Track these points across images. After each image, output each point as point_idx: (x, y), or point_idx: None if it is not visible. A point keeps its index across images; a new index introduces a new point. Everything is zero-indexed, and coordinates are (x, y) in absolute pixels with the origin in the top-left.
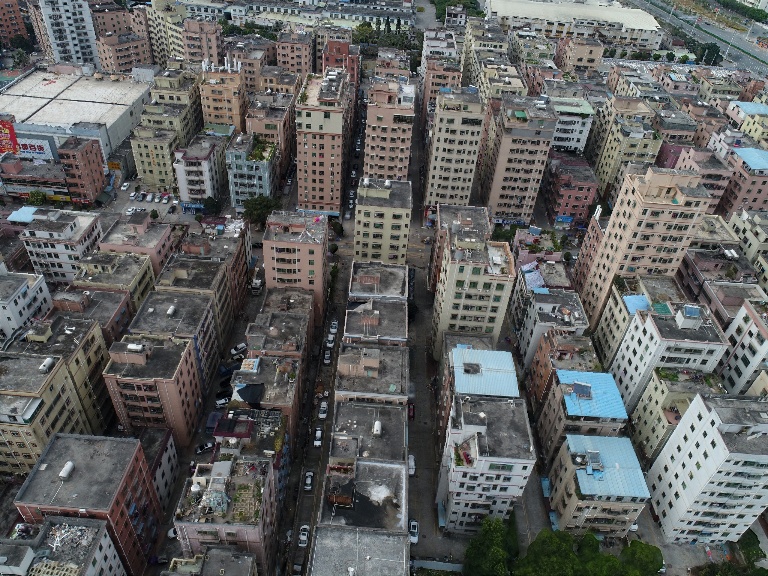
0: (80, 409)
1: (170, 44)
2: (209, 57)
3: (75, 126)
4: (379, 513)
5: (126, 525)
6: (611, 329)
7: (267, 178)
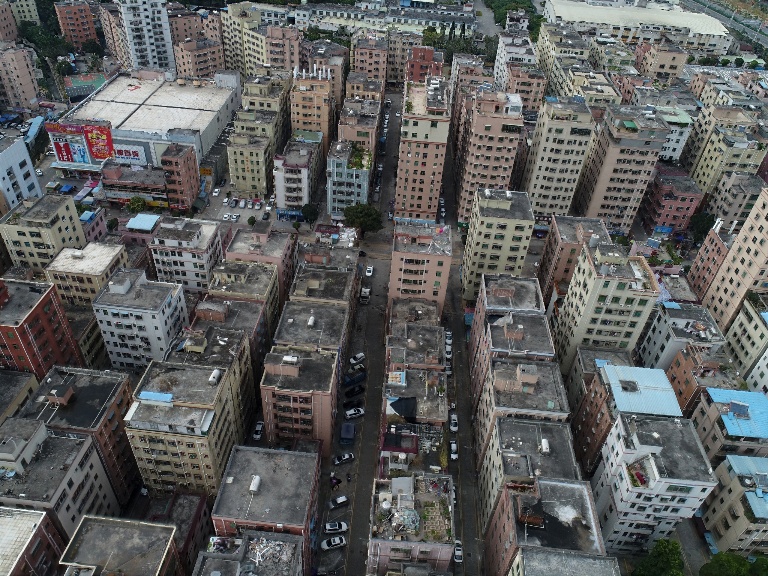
0: (234, 419)
1: (245, 49)
2: (290, 63)
3: (170, 132)
4: (571, 534)
5: (308, 539)
6: (743, 345)
7: (366, 186)
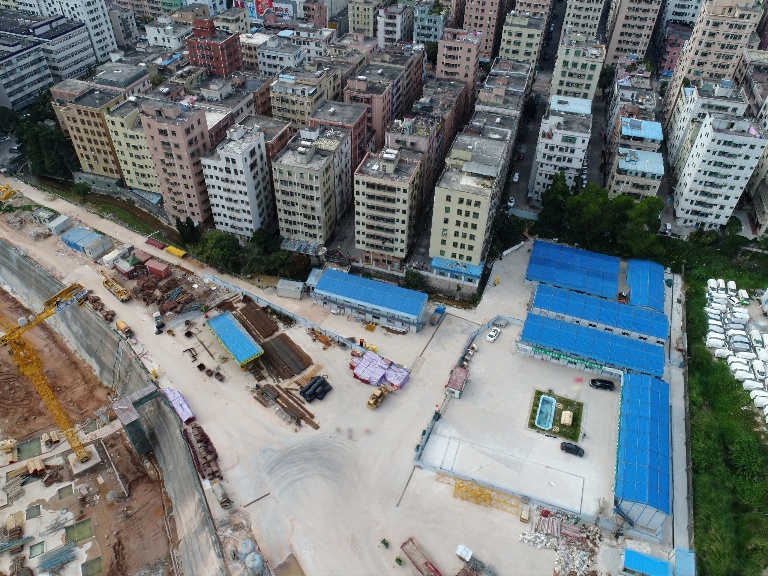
0: None
1: None
2: None
3: None
4: None
5: (356, 148)
6: (675, 116)
7: (441, 30)
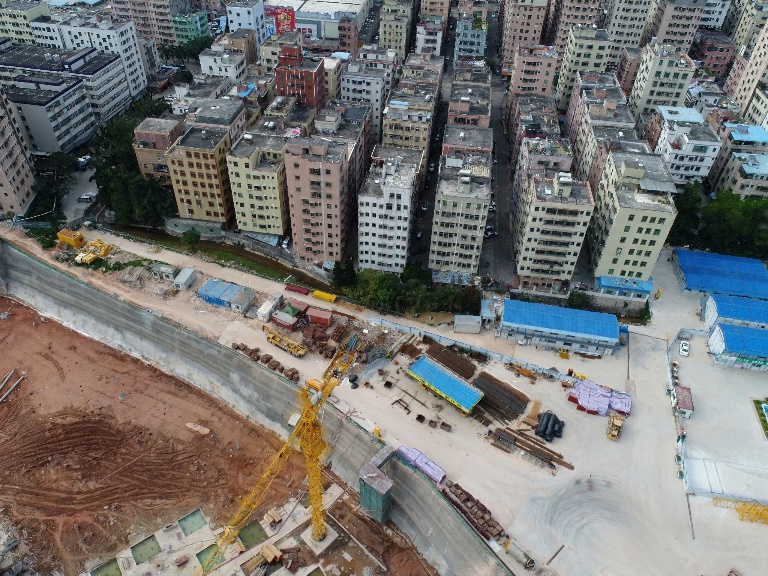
0: None
1: None
2: None
3: (337, 13)
4: None
5: None
6: (754, 118)
7: (484, 44)
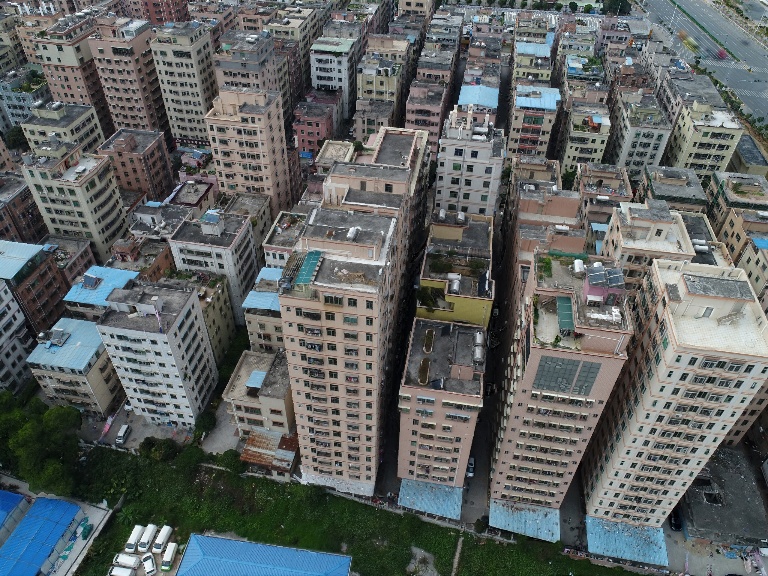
0: None
1: None
2: (60, 4)
3: None
4: None
5: None
6: None
7: None
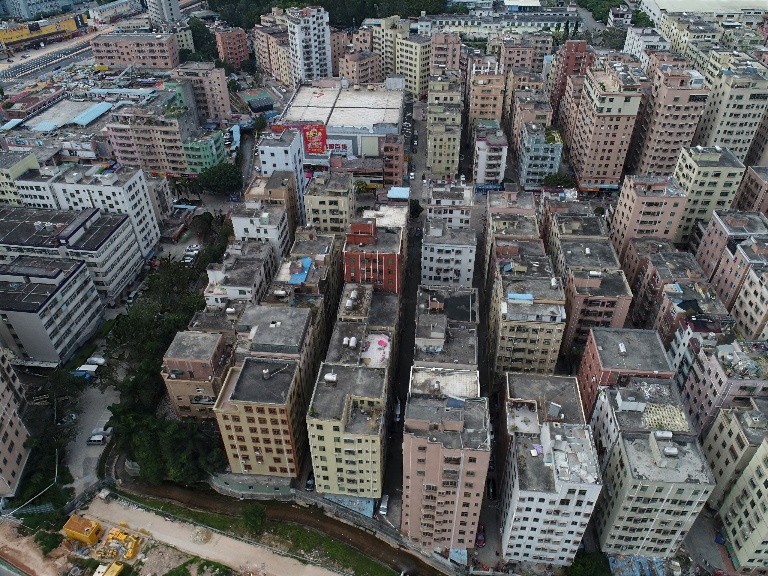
0: None
1: (397, 57)
2: (452, 64)
3: (376, 126)
4: None
5: None
6: None
7: (559, 158)
